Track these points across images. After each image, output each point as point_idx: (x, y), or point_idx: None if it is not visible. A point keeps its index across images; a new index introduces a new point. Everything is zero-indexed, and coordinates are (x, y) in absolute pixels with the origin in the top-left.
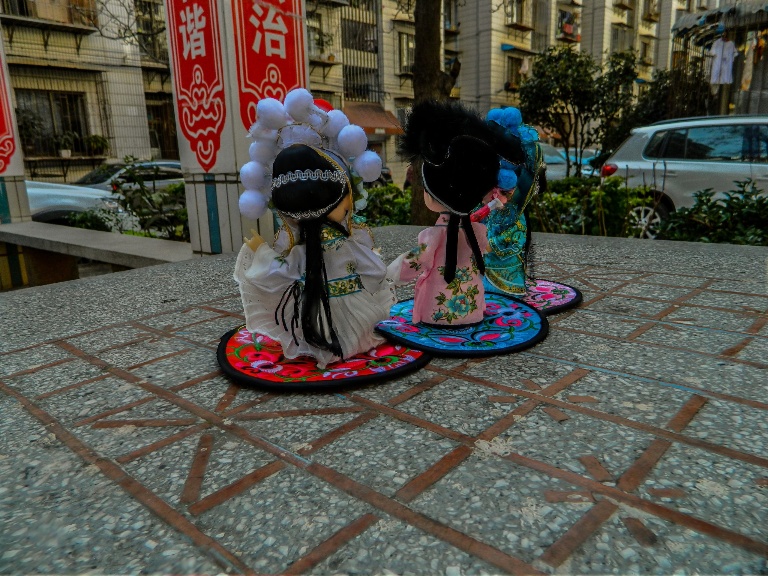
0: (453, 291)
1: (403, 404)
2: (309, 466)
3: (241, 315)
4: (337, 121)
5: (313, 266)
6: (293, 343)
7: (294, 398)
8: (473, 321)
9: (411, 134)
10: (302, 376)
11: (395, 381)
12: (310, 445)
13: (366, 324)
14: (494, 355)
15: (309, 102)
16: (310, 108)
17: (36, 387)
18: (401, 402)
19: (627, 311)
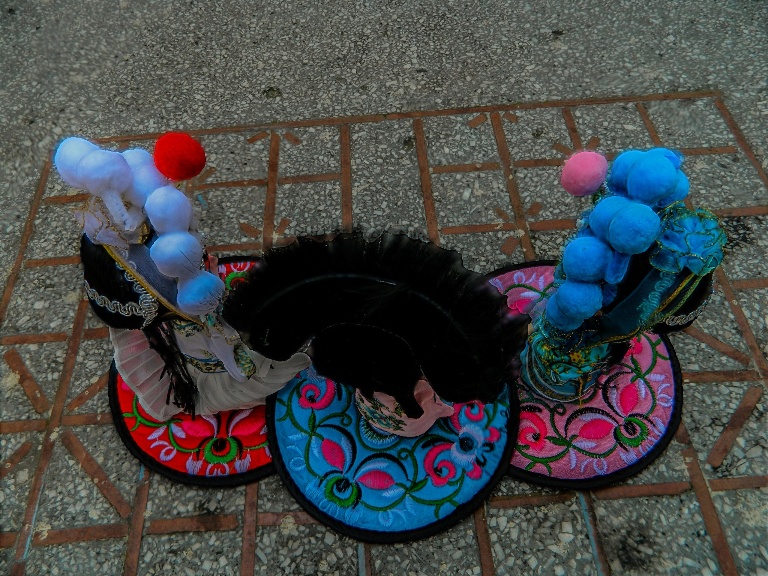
0: (372, 406)
1: (154, 539)
2: (18, 563)
3: (275, 194)
4: (152, 223)
5: (153, 344)
6: (159, 373)
7: (117, 440)
8: (399, 434)
9: (238, 306)
10: (145, 415)
11: (198, 489)
12: (47, 533)
13: (217, 407)
14: (327, 525)
15: (101, 190)
16: (103, 200)
17: (41, 241)
18: (157, 534)
19: (631, 567)
